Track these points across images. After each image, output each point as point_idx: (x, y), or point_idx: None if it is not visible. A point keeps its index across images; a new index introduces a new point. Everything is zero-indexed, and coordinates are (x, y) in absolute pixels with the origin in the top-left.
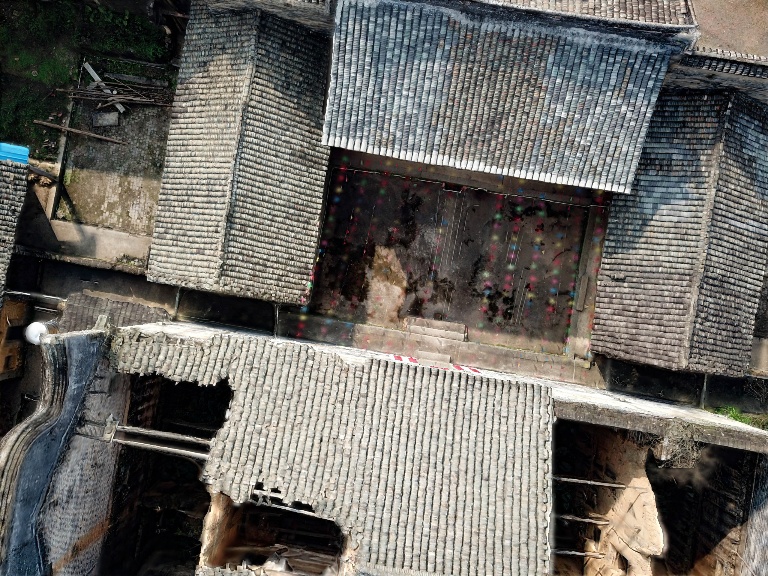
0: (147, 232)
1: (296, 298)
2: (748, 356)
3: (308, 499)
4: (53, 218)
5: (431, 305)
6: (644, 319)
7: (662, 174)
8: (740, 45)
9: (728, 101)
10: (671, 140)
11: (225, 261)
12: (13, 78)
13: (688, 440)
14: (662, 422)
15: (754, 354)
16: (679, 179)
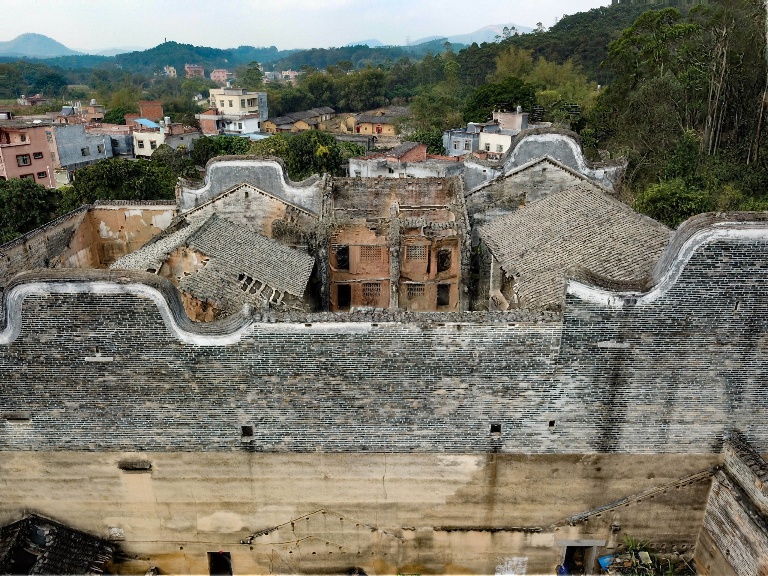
0: None
1: None
2: None
3: None
4: None
5: None
6: None
7: None
8: None
9: None
10: None
11: None
12: None
13: None
14: None
15: None
16: None
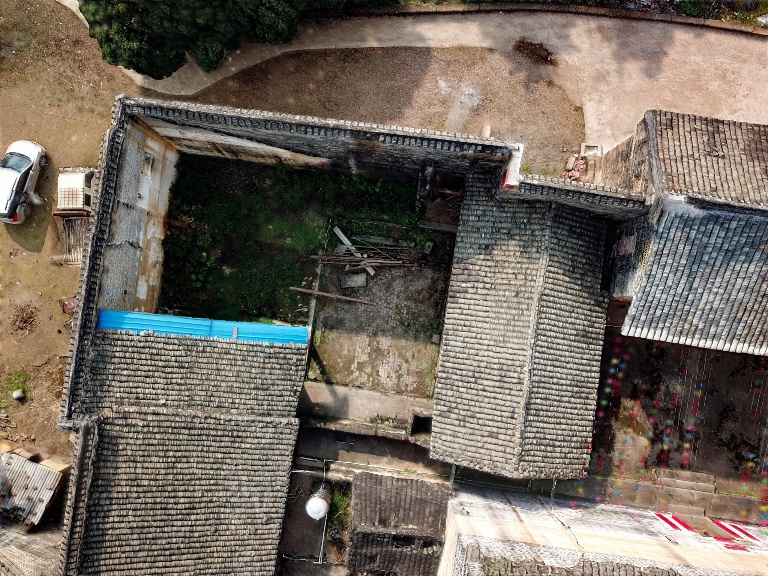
0: (397, 390)
1: (579, 473)
2: None
3: None
4: (305, 379)
5: (678, 455)
6: None
7: None
8: None
9: None
10: None
11: (523, 447)
12: (266, 245)
13: None
14: None
15: None
16: None
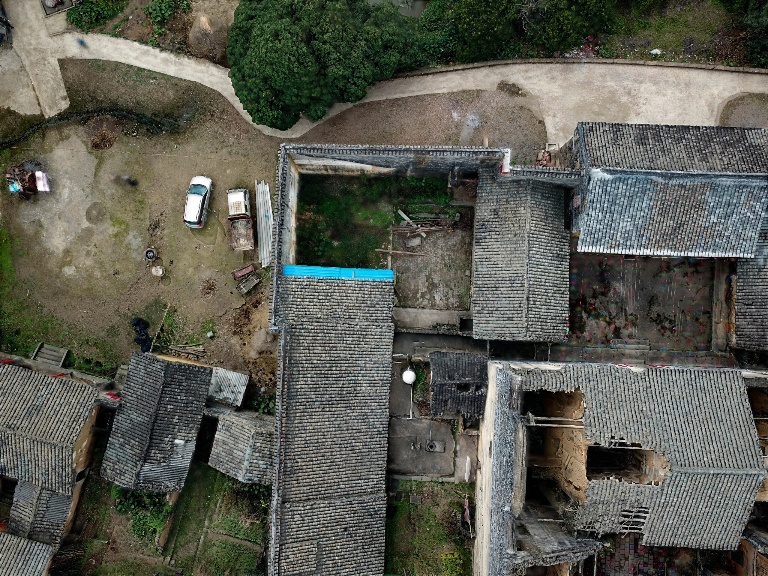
0: (447, 307)
1: (563, 338)
2: None
3: (639, 441)
4: None
5: (625, 330)
6: (767, 326)
7: (767, 241)
8: None
9: None
10: None
11: (528, 323)
12: (358, 225)
13: None
14: None
15: None
16: None
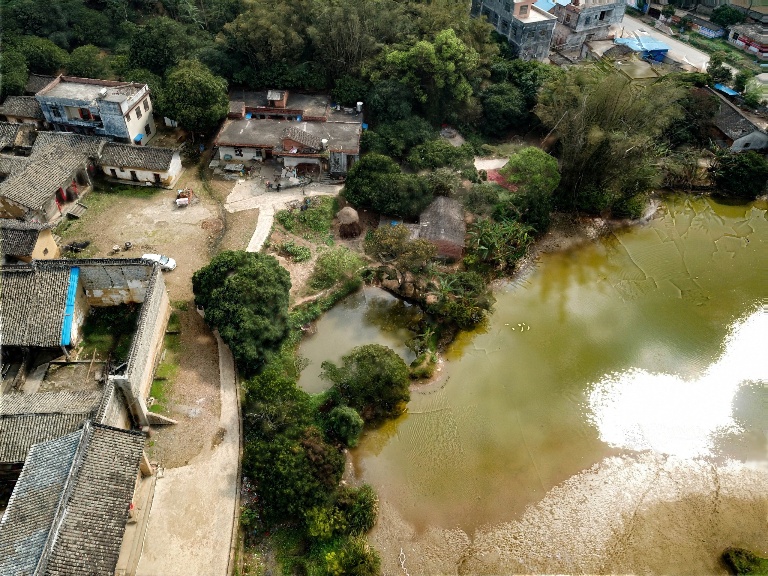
0: None
1: None
2: None
3: None
4: (50, 363)
5: None
6: None
7: None
8: None
9: None
10: None
11: None
12: None
13: None
14: None
15: None
16: None
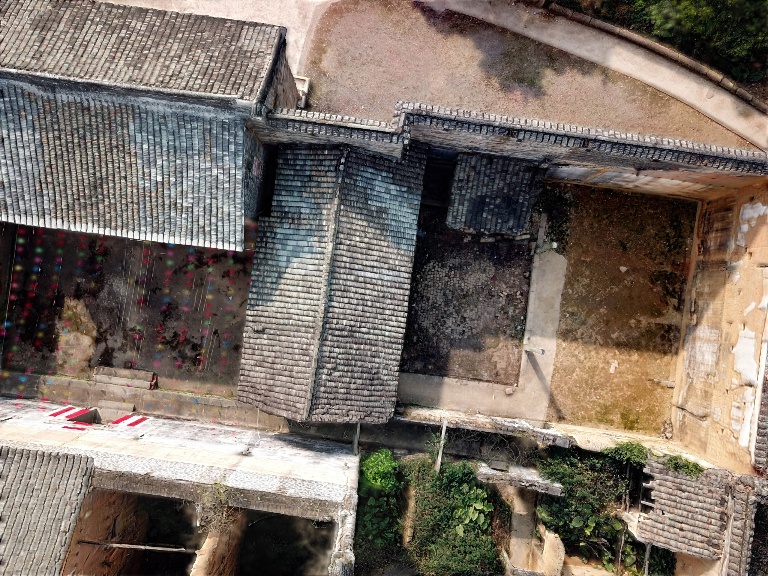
0: None
1: None
2: (392, 402)
3: None
4: None
5: (122, 353)
6: (279, 371)
7: (293, 227)
8: (425, 86)
9: (341, 156)
10: (301, 194)
11: None
12: None
13: (220, 506)
14: (200, 488)
15: (436, 393)
16: (306, 233)
